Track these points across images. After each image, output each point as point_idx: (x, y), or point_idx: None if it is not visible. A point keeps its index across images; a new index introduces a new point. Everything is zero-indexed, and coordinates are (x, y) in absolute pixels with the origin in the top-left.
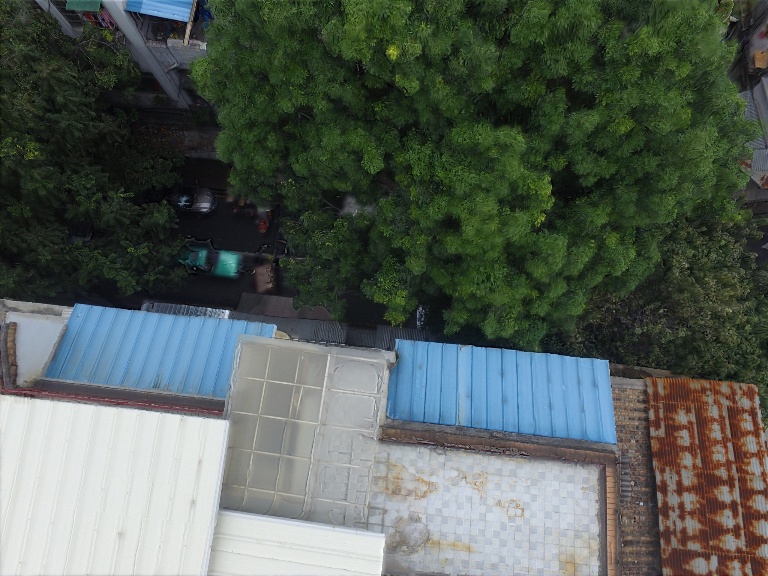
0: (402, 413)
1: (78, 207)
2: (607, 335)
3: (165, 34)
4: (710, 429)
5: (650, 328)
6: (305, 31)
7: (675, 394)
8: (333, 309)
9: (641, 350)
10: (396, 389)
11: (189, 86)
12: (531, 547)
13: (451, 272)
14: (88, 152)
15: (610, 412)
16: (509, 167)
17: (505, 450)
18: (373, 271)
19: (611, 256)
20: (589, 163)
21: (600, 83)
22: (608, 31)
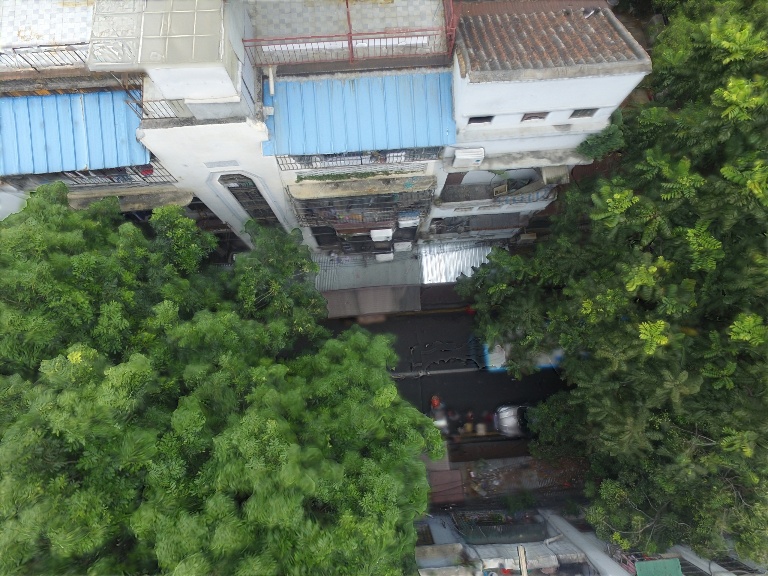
0: None
1: (566, 312)
2: None
3: None
4: None
5: None
6: None
7: None
8: (251, 224)
9: None
10: None
11: (534, 527)
12: (13, 12)
13: (107, 245)
14: None
15: None
16: None
17: (15, 55)
18: None
19: None
20: None
21: None
22: None
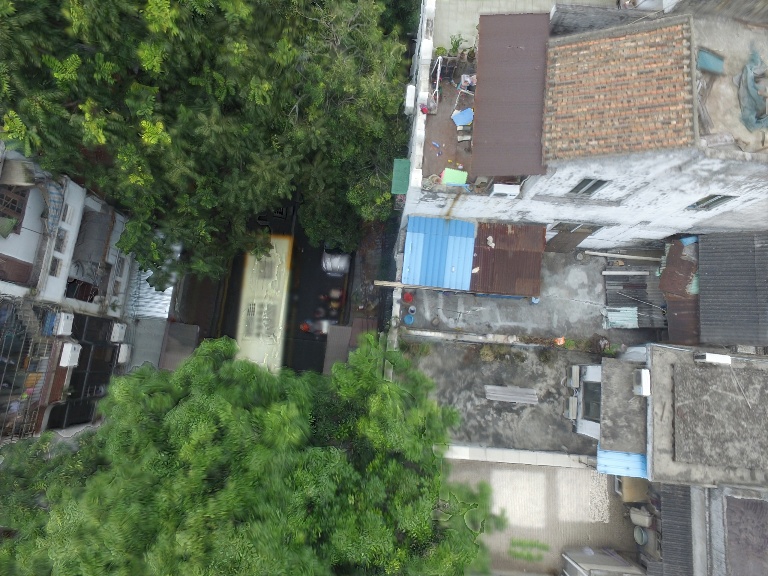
0: None
1: None
2: None
3: None
4: None
5: None
6: None
7: None
8: None
9: None
10: None
11: (393, 265)
12: None
13: None
14: (292, 180)
15: None
16: None
17: None
18: None
19: None
20: None
21: None
22: None
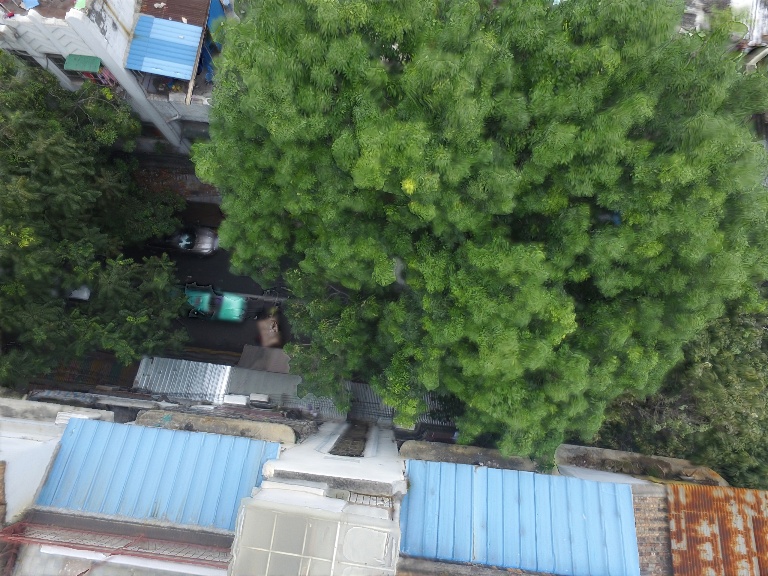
0: (413, 546)
1: (75, 276)
2: (623, 423)
3: (167, 85)
4: (734, 542)
5: (670, 422)
6: (314, 142)
7: (697, 503)
8: (339, 403)
9: (659, 439)
10: (407, 518)
11: (191, 135)
12: None
13: (465, 380)
14: (87, 208)
15: (634, 546)
16: (531, 301)
17: None
18: (381, 360)
19: (634, 371)
20: (613, 280)
21: (627, 204)
22: (637, 151)
